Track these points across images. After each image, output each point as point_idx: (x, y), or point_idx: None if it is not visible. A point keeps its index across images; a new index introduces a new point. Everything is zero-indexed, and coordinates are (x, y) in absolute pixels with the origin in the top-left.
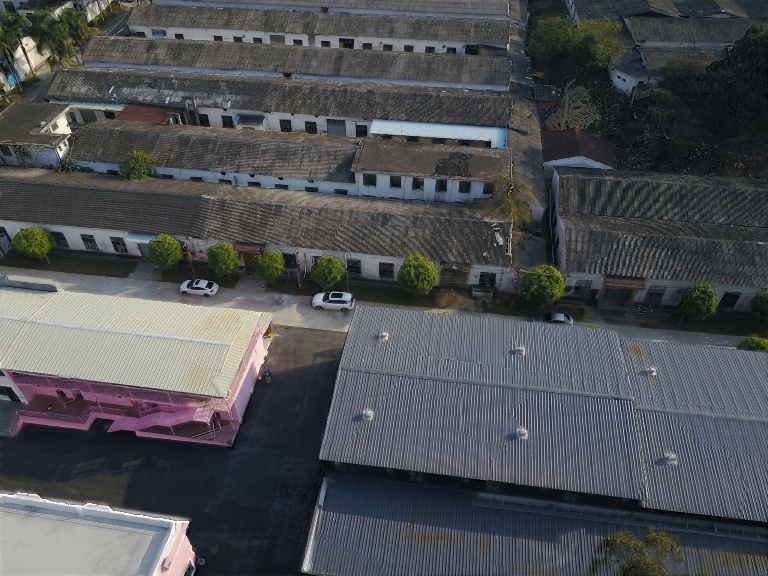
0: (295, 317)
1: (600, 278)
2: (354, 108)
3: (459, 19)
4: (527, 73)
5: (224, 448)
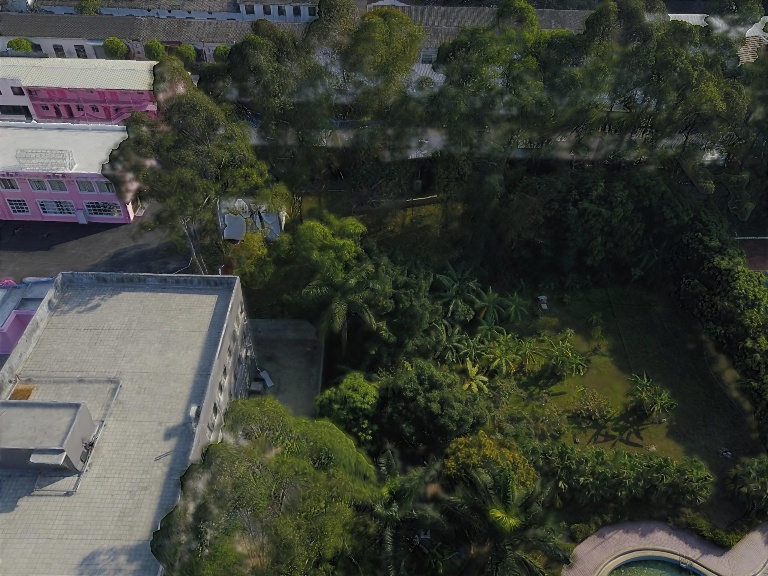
0: None
1: None
2: None
3: None
4: None
5: None
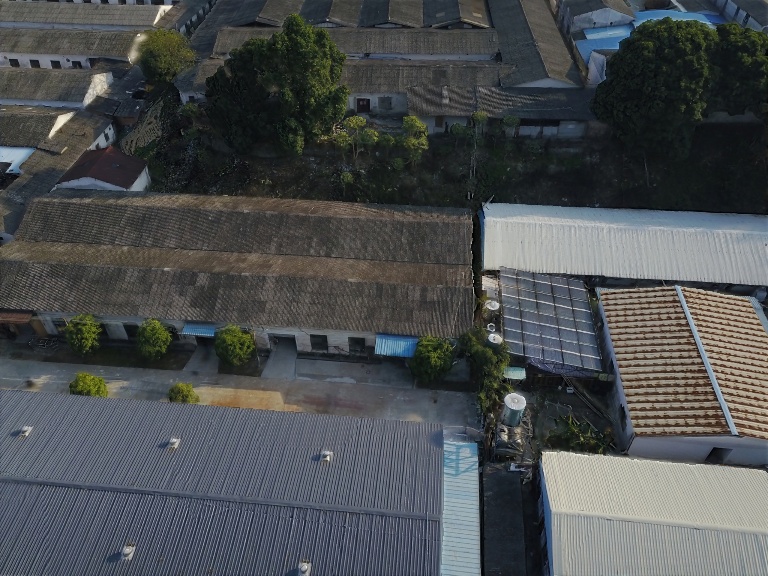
0: None
1: None
2: None
3: (88, 31)
4: (133, 87)
5: None
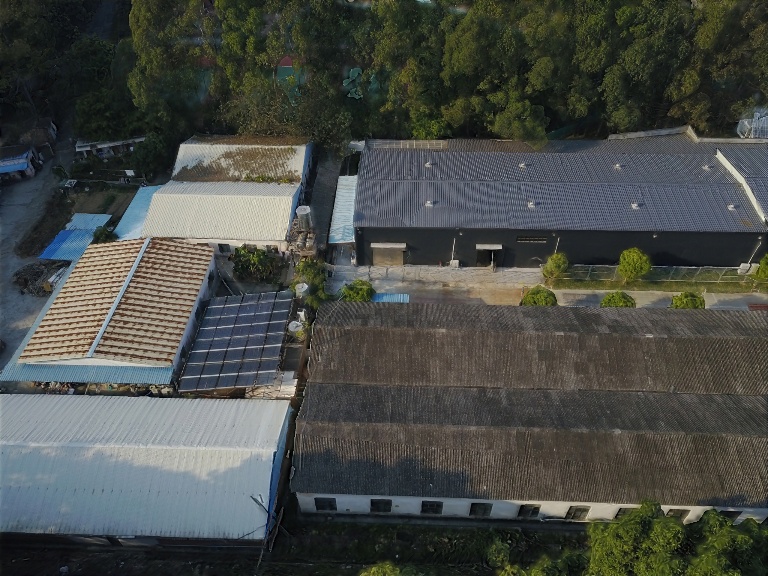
0: None
1: None
2: None
3: None
4: None
5: None
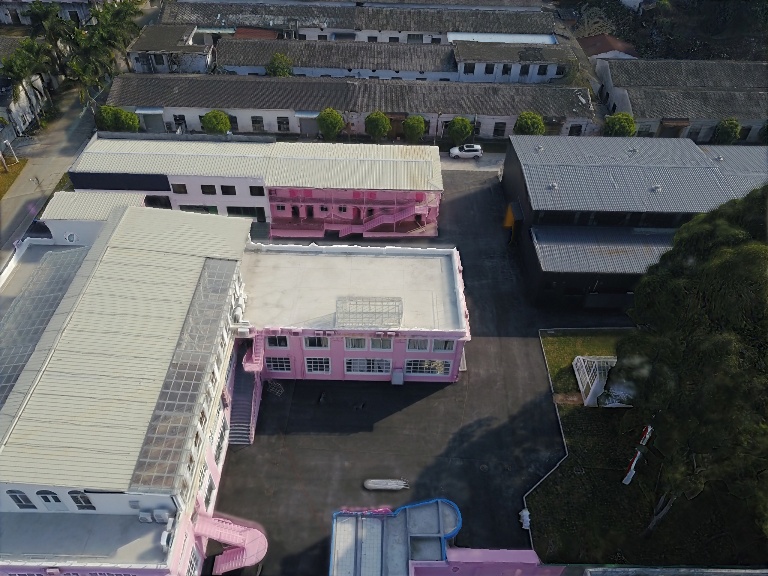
0: (441, 164)
1: (657, 122)
2: (430, 24)
3: None
4: (547, 1)
5: (432, 237)
